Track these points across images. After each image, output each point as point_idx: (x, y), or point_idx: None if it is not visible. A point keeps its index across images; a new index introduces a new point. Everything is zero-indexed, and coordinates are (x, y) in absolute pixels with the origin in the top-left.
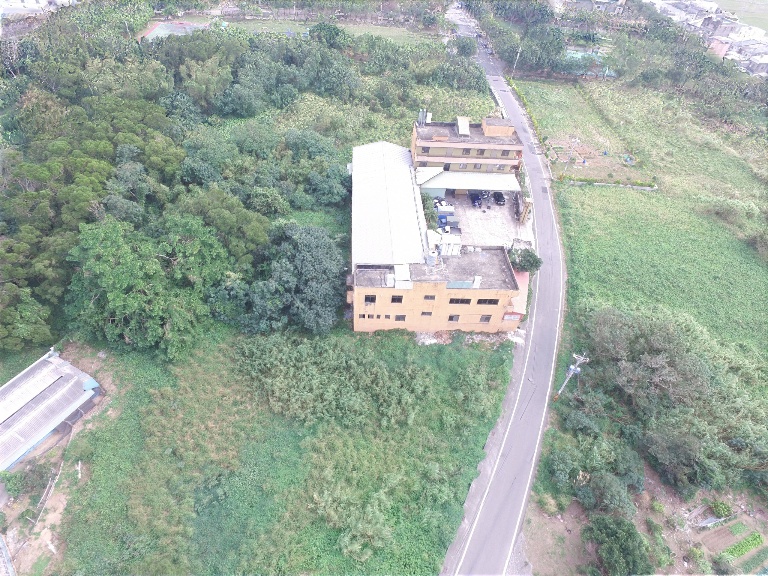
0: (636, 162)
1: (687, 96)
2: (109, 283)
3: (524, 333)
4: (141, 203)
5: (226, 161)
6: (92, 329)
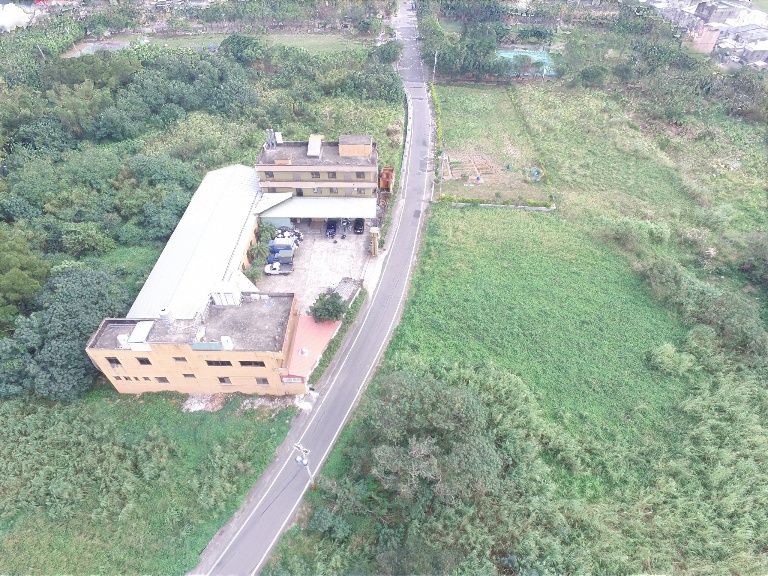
0: (541, 177)
1: (638, 95)
2: None
3: (316, 396)
4: None
5: (46, 194)
6: None
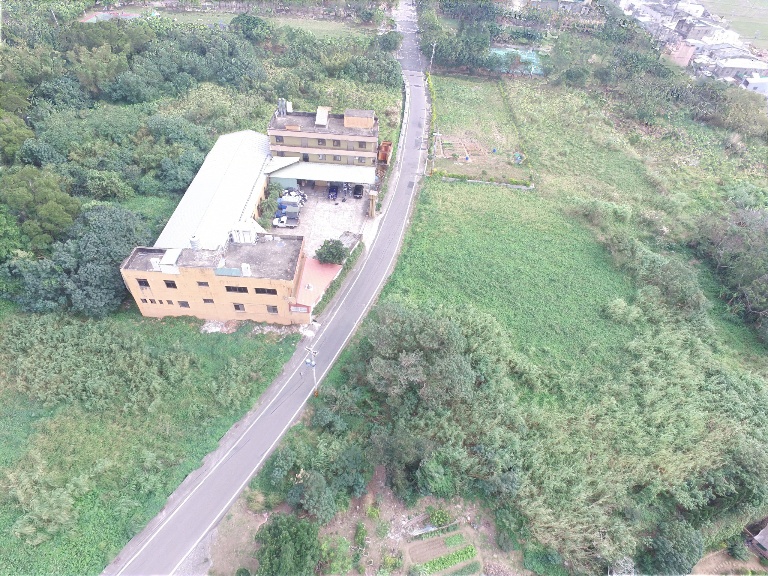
0: (523, 160)
1: (615, 97)
2: None
3: (318, 327)
4: None
5: (71, 143)
6: None
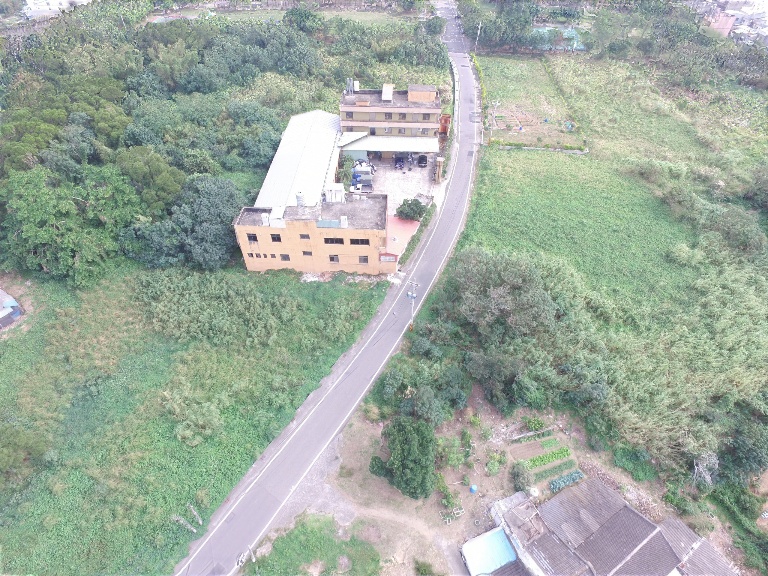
0: (575, 128)
1: (659, 67)
2: (23, 217)
3: (403, 275)
4: (84, 162)
5: (166, 127)
6: (18, 259)
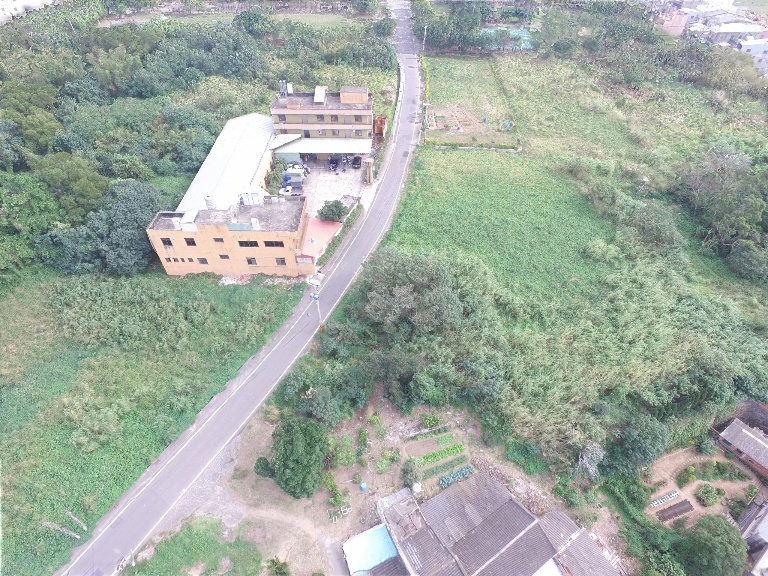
0: (512, 127)
1: (604, 65)
2: None
3: (323, 276)
4: (9, 169)
5: (96, 132)
6: None
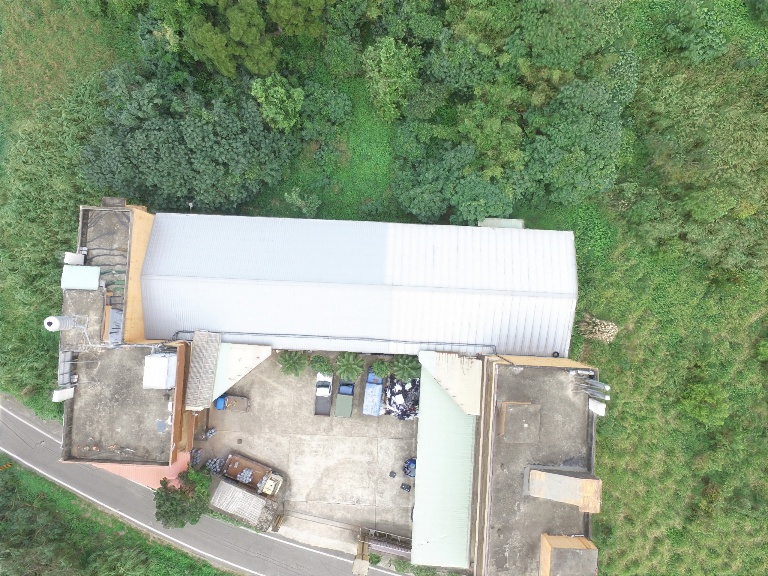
0: None
1: None
2: None
3: None
4: None
5: None
6: None
